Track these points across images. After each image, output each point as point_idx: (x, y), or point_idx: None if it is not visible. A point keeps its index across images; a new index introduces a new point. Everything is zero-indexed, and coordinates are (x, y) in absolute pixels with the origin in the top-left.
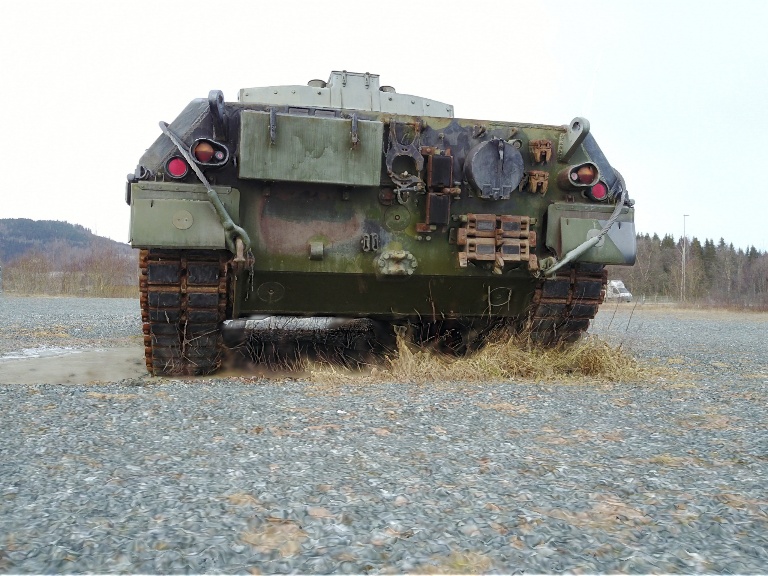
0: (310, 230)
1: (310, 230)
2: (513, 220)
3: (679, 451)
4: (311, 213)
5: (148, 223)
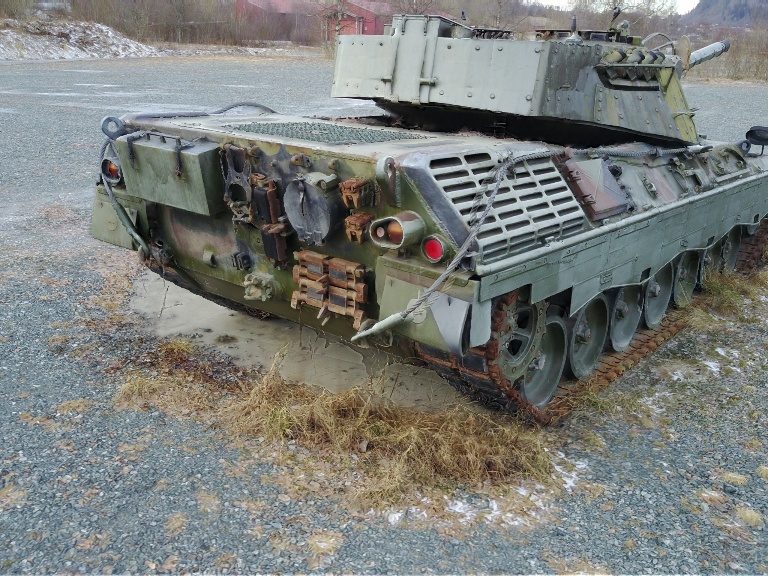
0: (203, 240)
1: (203, 240)
2: (339, 268)
3: None
4: (200, 225)
5: (98, 221)
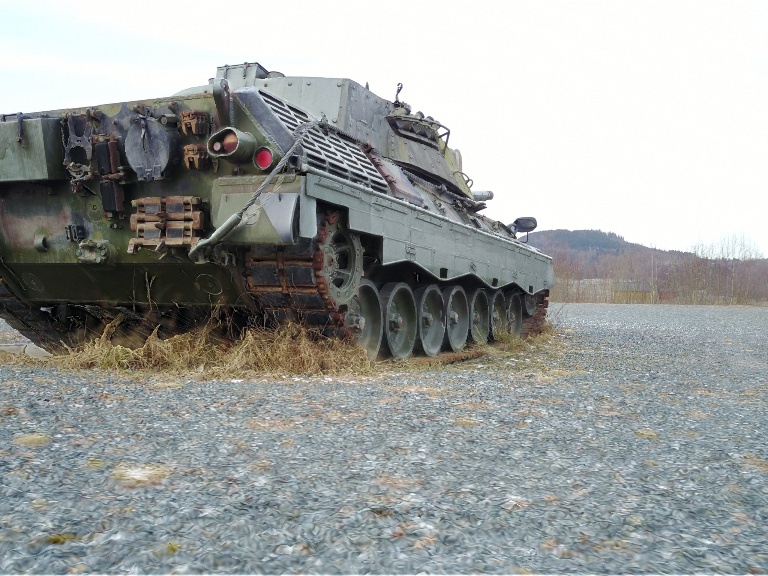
0: (35, 225)
1: (35, 225)
2: (176, 201)
3: None
4: (33, 209)
5: None
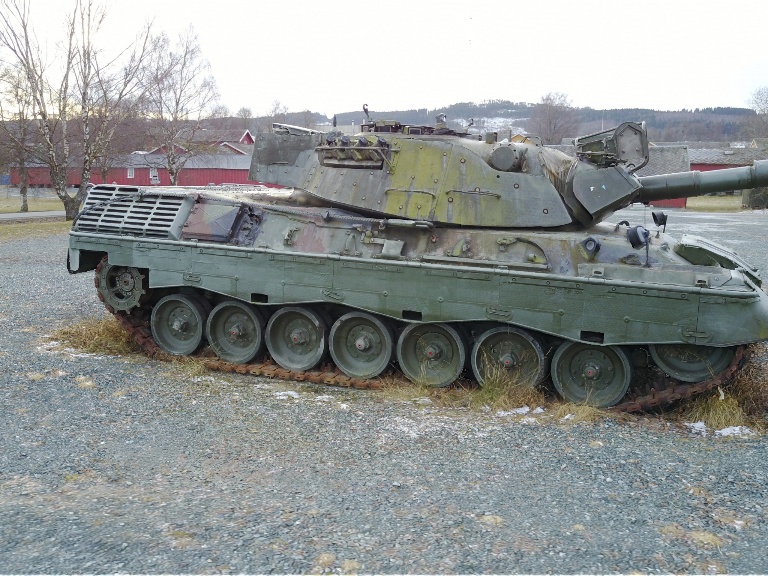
0: None
1: None
2: None
3: (3, 306)
4: None
5: None
